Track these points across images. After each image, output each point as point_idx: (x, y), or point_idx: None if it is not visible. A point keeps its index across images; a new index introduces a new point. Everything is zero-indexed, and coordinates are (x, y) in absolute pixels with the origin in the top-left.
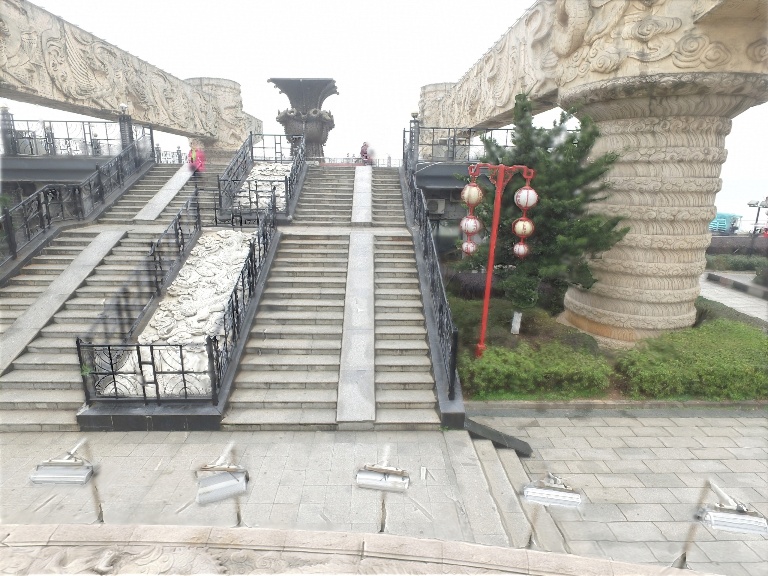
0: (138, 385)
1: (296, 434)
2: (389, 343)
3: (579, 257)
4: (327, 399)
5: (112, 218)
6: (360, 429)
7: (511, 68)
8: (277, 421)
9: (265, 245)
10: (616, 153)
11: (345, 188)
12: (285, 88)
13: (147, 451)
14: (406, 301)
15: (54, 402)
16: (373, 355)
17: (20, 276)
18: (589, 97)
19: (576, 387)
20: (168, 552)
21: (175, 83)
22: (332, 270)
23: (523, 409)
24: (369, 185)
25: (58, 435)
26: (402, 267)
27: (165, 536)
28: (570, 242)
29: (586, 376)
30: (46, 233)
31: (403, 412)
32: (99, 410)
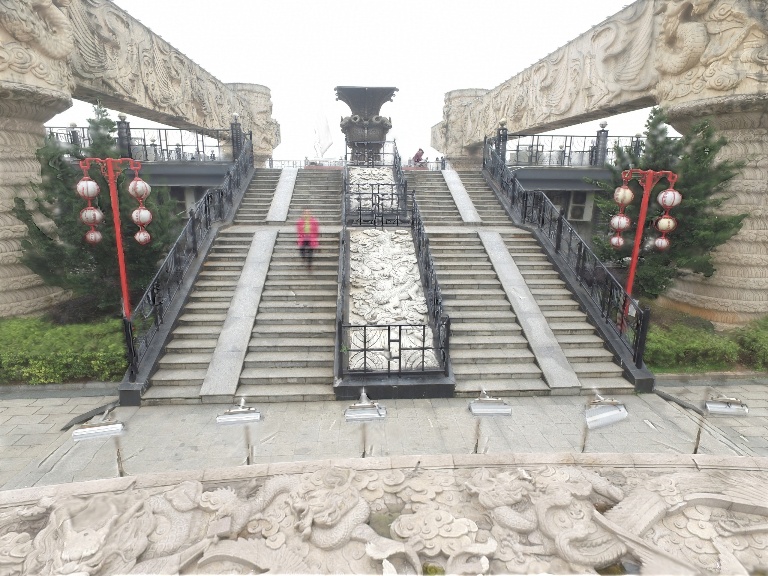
0: (384, 360)
1: (519, 399)
2: (558, 325)
3: (706, 249)
4: (532, 370)
5: (244, 220)
6: (568, 394)
7: (572, 79)
8: (501, 388)
9: (419, 242)
10: (724, 159)
11: (441, 191)
12: (349, 96)
13: (410, 413)
14: (554, 290)
15: (304, 377)
16: (553, 334)
17: (204, 272)
18: (702, 111)
19: (709, 361)
20: (557, 468)
21: (222, 89)
22: (478, 264)
23: (668, 380)
24: (463, 188)
25: (321, 404)
26: (535, 261)
27: (541, 459)
28: (712, 236)
29: (720, 351)
30: (209, 233)
31: (598, 380)
32: (353, 382)
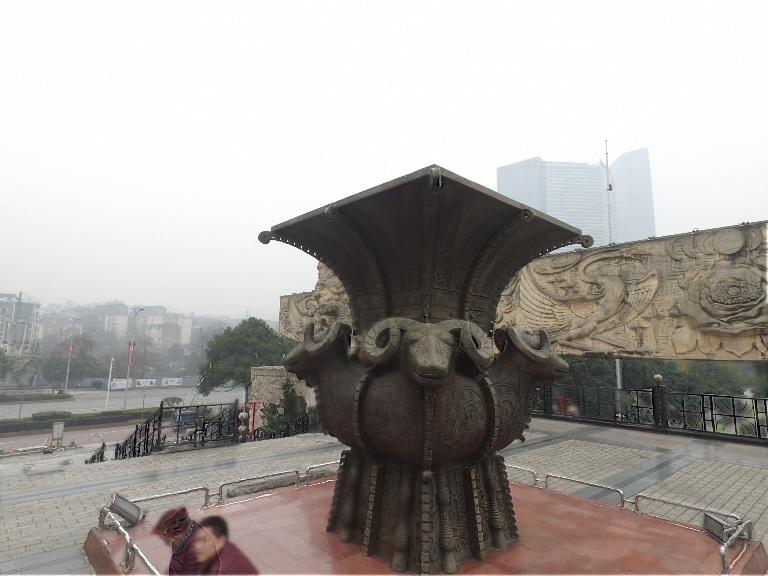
0: None
1: None
2: None
3: None
4: None
5: None
6: None
7: None
8: None
9: None
10: None
11: None
12: None
13: None
14: None
15: None
16: None
17: None
18: None
19: None
20: None
21: None
22: None
23: None
24: None
25: None
26: None
27: None
28: None
29: None
30: None
31: None
32: None
